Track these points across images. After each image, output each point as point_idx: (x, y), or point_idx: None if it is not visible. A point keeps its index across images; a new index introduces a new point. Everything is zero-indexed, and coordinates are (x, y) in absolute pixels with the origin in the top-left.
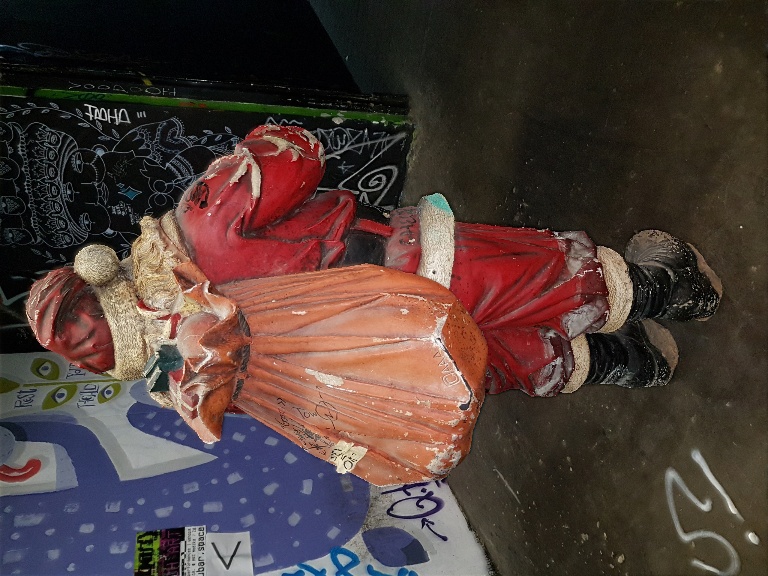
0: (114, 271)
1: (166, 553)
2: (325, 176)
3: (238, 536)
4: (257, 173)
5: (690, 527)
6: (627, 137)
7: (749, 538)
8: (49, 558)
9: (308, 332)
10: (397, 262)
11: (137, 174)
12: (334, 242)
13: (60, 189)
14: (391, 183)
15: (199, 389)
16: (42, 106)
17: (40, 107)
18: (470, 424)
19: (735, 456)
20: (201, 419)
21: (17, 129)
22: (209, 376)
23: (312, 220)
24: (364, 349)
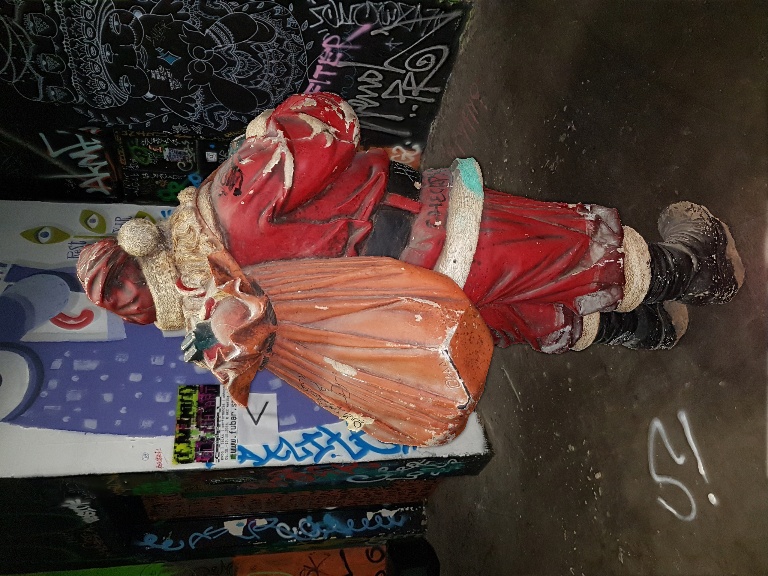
0: (154, 245)
1: (204, 406)
2: (371, 52)
3: (266, 397)
4: (290, 162)
5: (661, 471)
6: (691, 89)
7: (708, 497)
8: (105, 400)
9: (328, 326)
10: (421, 246)
11: (176, 39)
12: (362, 222)
13: (99, 50)
14: (440, 64)
15: (229, 372)
16: None
17: None
18: None
19: (715, 429)
20: (231, 394)
21: None
22: (238, 362)
23: (342, 198)
24: (377, 350)
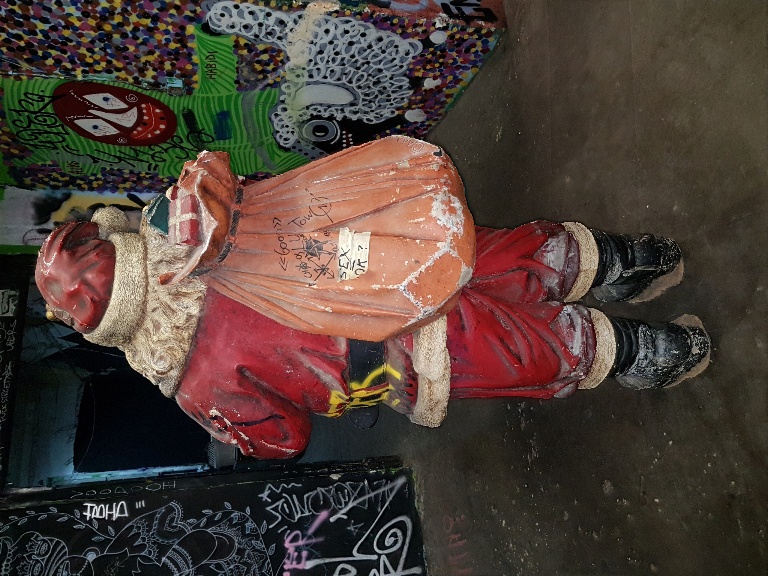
0: (124, 220)
1: None
2: (336, 542)
3: None
4: None
5: None
6: None
7: None
8: None
9: None
10: None
11: None
12: None
13: None
14: (408, 538)
15: None
16: (40, 512)
17: (38, 514)
18: (453, 175)
19: None
20: (199, 197)
21: (7, 544)
22: None
23: None
24: None
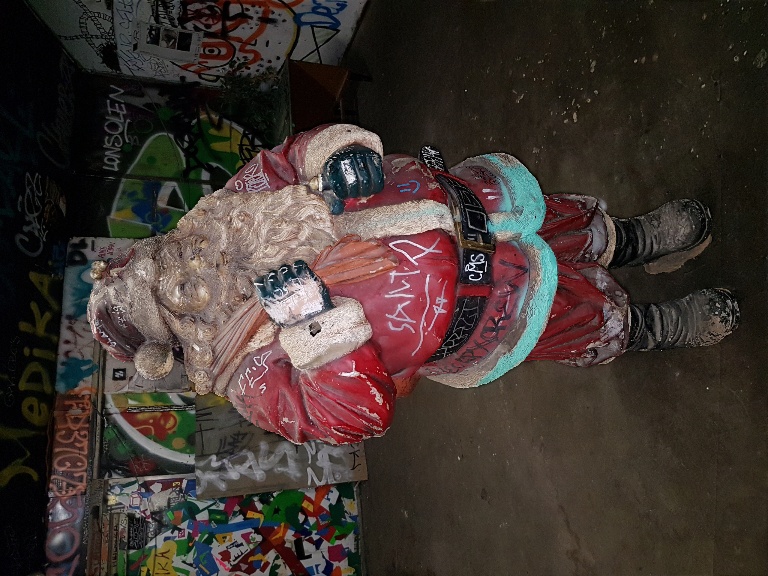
0: None
1: None
2: None
3: None
4: None
5: None
6: None
7: None
8: None
9: None
10: None
11: None
12: None
13: None
14: None
15: None
16: None
17: None
18: None
19: None
20: None
21: None
22: None
23: None
24: None
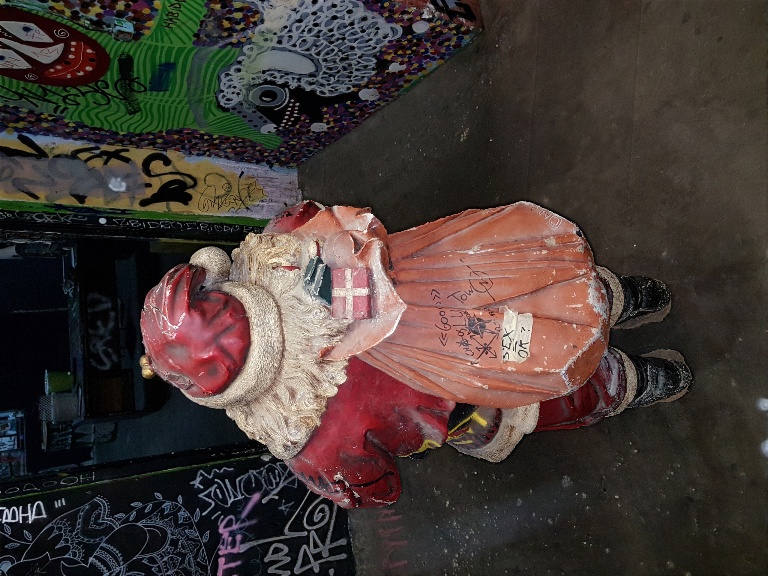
0: (229, 263)
1: None
2: (268, 523)
3: None
4: None
5: None
6: None
7: None
8: None
9: None
10: None
11: None
12: None
13: None
14: (335, 512)
15: (372, 250)
16: None
17: None
18: None
19: None
20: (385, 275)
21: None
22: None
23: None
24: (479, 222)
